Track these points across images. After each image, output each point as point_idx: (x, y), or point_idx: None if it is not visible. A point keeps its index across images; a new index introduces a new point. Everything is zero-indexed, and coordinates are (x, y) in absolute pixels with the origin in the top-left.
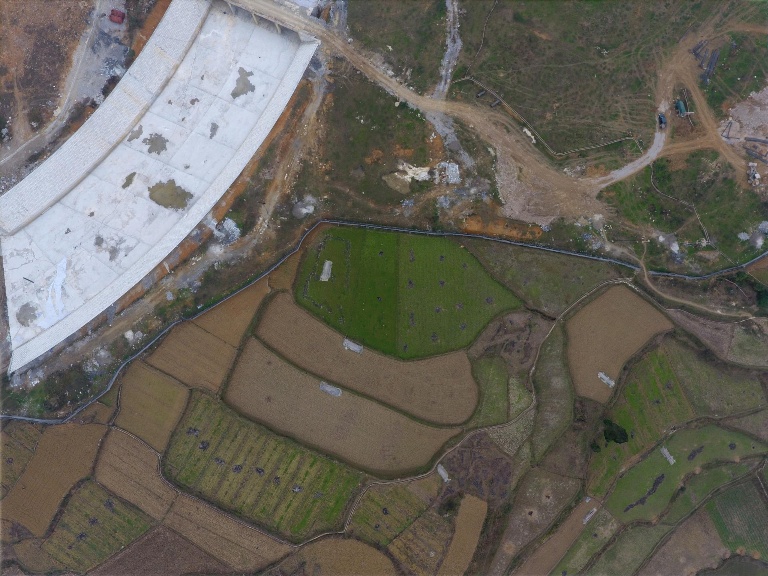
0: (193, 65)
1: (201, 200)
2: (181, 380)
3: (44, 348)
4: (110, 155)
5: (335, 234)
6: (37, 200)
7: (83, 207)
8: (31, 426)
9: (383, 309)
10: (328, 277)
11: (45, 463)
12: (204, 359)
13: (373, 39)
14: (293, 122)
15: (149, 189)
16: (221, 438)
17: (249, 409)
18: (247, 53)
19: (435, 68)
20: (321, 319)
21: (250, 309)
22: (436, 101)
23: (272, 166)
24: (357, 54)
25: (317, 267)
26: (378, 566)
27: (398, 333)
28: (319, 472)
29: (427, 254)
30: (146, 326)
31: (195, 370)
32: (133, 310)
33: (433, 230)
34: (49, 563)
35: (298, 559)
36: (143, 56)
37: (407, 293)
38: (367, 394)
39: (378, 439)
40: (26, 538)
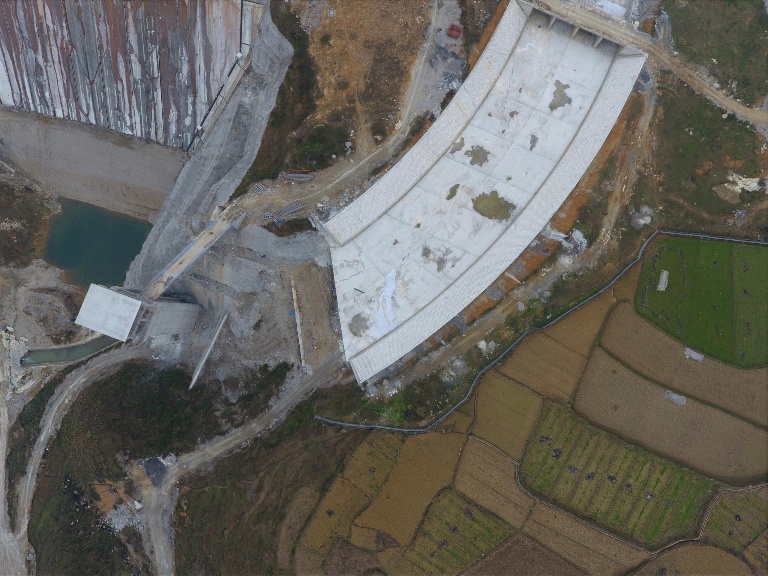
0: (511, 78)
1: (529, 211)
2: (533, 389)
3: (392, 358)
4: (434, 167)
5: (670, 244)
6: (371, 212)
7: (409, 218)
8: (392, 435)
9: (719, 318)
10: (665, 287)
11: (408, 472)
12: (555, 368)
13: (698, 52)
14: (628, 134)
15: (473, 200)
16: (573, 446)
17: (597, 417)
18: (563, 66)
19: (762, 81)
20: (661, 328)
21: (597, 319)
22: (766, 113)
23: (613, 178)
24: (683, 67)
25: (654, 277)
26: (736, 572)
27: (735, 342)
28: (670, 479)
29: (760, 264)
30: (499, 336)
31: (547, 379)
32: (485, 320)
33: (765, 240)
34: (412, 571)
35: (657, 566)
36: (476, 70)
37: (742, 302)
38: (710, 402)
39: (723, 446)
40: (390, 546)
